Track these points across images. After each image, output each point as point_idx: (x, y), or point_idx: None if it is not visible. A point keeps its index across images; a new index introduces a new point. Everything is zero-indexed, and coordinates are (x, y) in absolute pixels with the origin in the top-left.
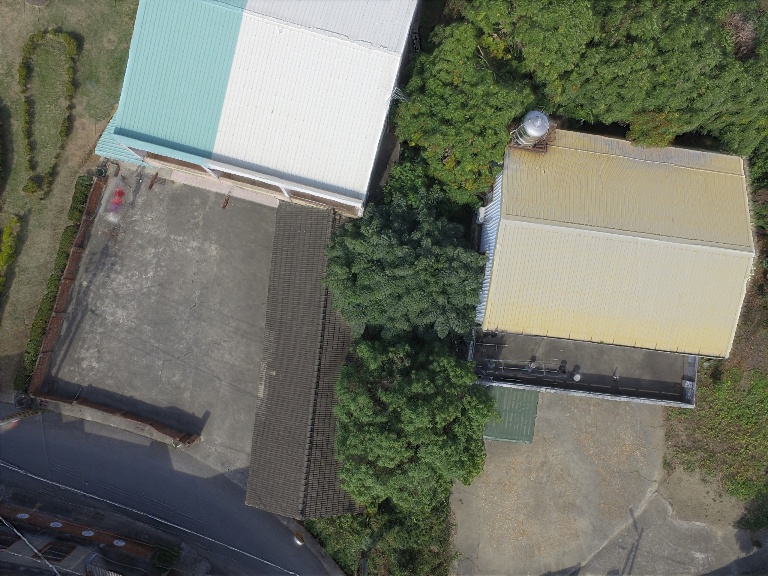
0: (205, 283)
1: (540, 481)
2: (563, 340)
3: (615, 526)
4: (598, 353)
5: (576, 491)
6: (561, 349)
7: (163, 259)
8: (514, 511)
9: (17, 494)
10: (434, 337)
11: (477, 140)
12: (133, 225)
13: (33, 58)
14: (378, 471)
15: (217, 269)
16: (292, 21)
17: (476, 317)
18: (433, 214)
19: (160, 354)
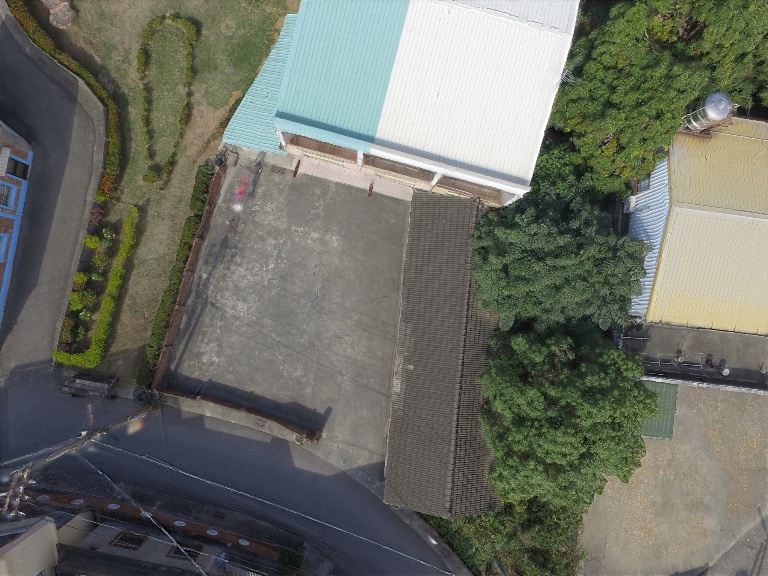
0: (326, 275)
1: (668, 479)
2: (709, 333)
3: (743, 525)
4: (744, 347)
5: (704, 489)
6: (707, 343)
7: (284, 251)
8: (641, 510)
9: (136, 492)
10: (586, 330)
11: (654, 124)
12: (253, 216)
13: (151, 44)
14: (545, 468)
15: (338, 261)
16: (461, 1)
17: (632, 309)
18: (586, 203)
19: (281, 348)
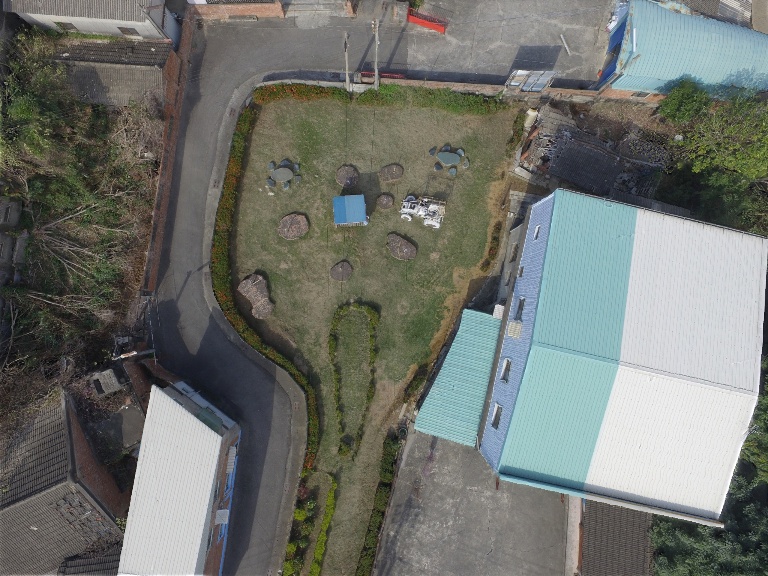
0: (499, 529)
1: None
2: None
3: None
4: None
5: None
6: None
7: (461, 509)
8: None
9: None
10: None
11: None
12: (432, 478)
13: (338, 328)
14: None
15: (509, 516)
16: (660, 369)
17: None
18: (758, 506)
19: None
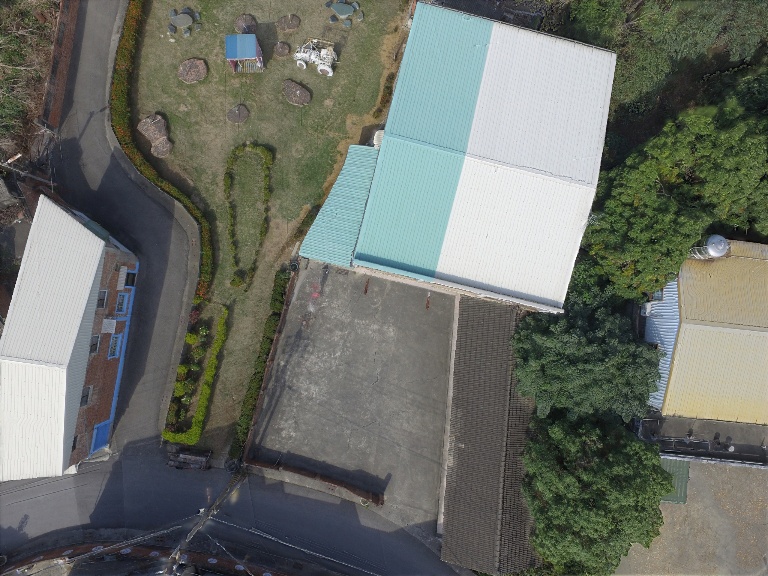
0: (385, 361)
1: (683, 533)
2: None
3: (751, 573)
4: (747, 426)
5: (715, 542)
6: (714, 423)
7: (348, 341)
8: (661, 560)
9: (229, 547)
10: (611, 417)
11: (666, 260)
12: (322, 311)
13: (234, 168)
14: None
15: (395, 348)
16: (505, 161)
17: (650, 401)
18: (609, 311)
19: (348, 424)
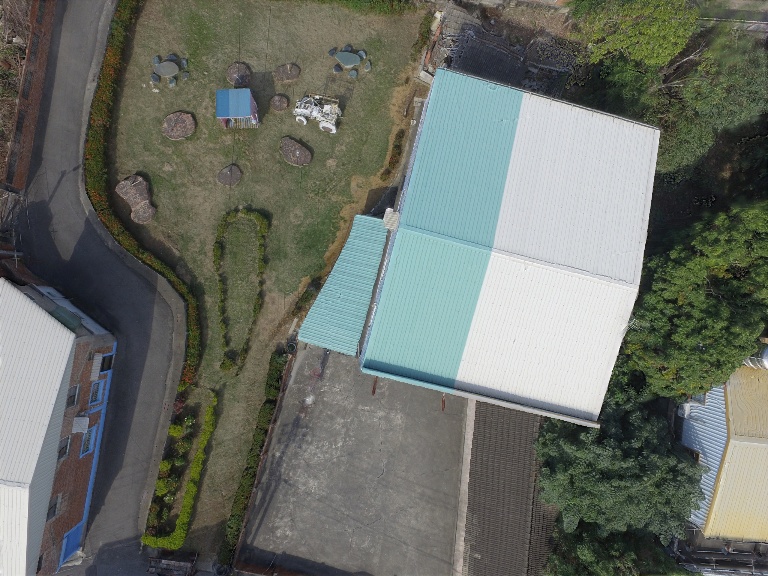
0: (392, 452)
1: None
2: None
3: None
4: None
5: None
6: None
7: (351, 429)
8: None
9: None
10: (645, 533)
11: (716, 373)
12: (322, 396)
13: (225, 236)
14: None
15: (403, 437)
16: (536, 257)
17: None
18: (645, 416)
19: (350, 522)
